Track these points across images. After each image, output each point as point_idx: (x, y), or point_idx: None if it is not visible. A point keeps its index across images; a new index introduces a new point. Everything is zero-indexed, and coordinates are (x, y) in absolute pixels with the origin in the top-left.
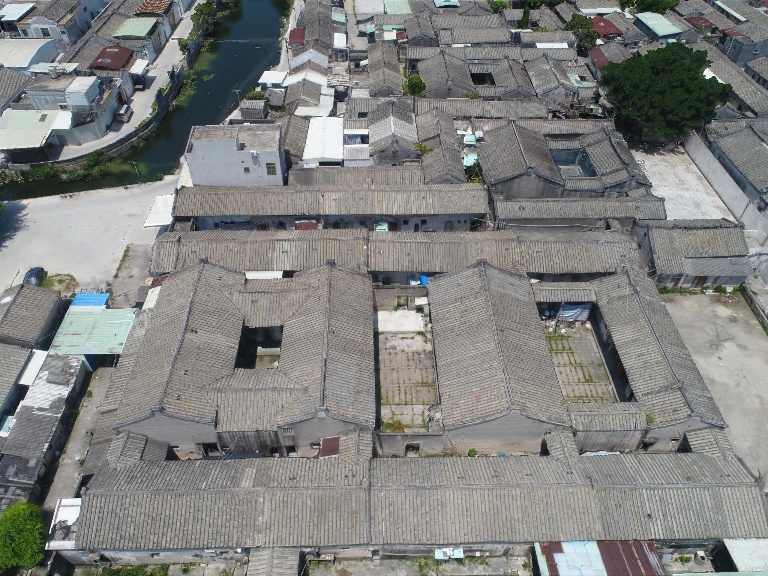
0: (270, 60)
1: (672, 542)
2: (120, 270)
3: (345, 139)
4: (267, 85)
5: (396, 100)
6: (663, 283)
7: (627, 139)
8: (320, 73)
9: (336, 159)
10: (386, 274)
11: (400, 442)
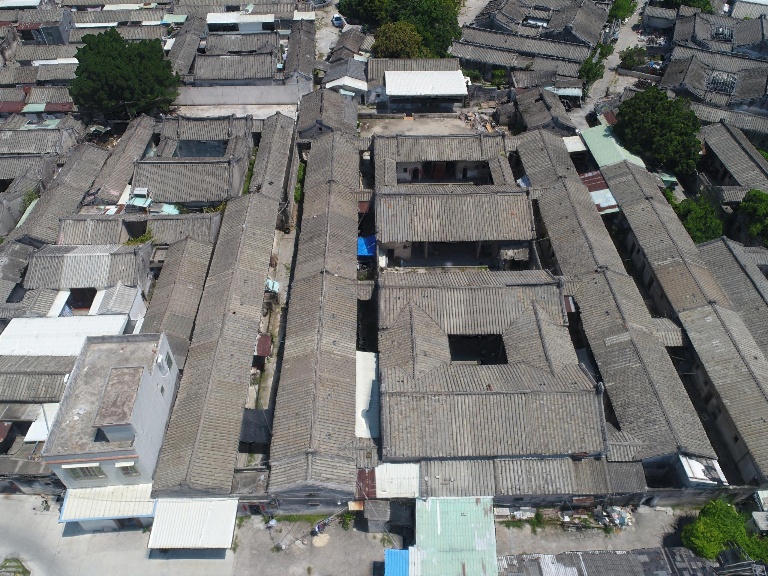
0: None
1: None
2: None
3: None
4: None
5: (6, 258)
6: None
7: None
8: None
9: (125, 321)
10: None
11: None
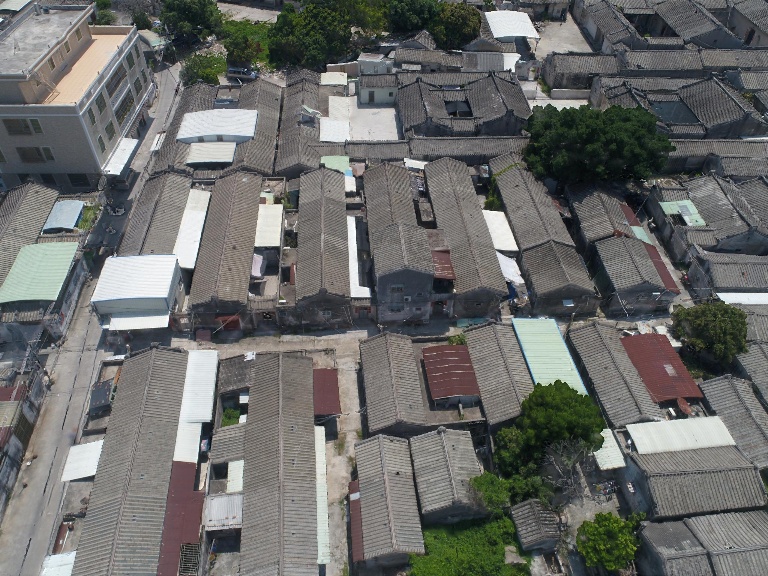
0: None
1: None
2: None
3: None
4: None
5: None
6: None
7: None
8: None
9: None
10: None
11: (717, 18)
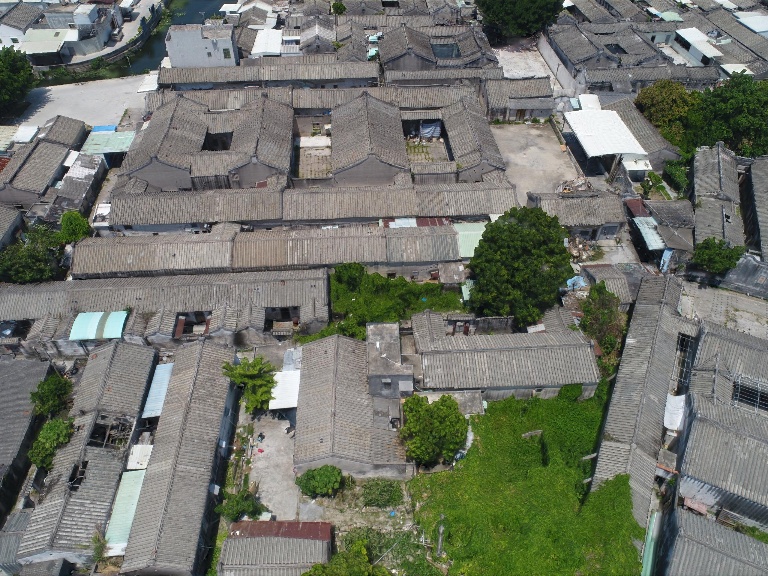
0: (230, 3)
1: (460, 218)
2: (122, 121)
3: (283, 43)
4: (226, 13)
5: (322, 17)
6: (496, 116)
7: (496, 43)
8: (267, 3)
9: (275, 53)
10: (306, 113)
11: (306, 186)
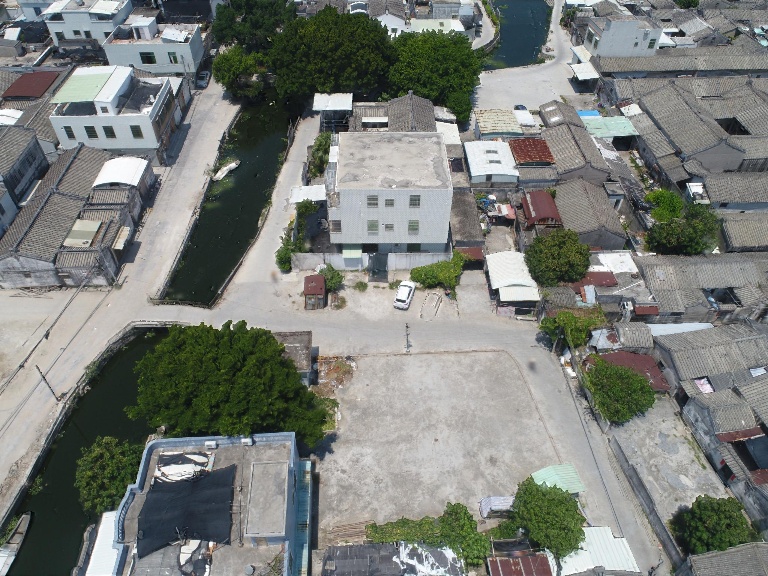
0: None
1: None
2: None
3: None
4: None
5: (685, 11)
6: None
7: None
8: None
9: (672, 44)
10: None
11: None
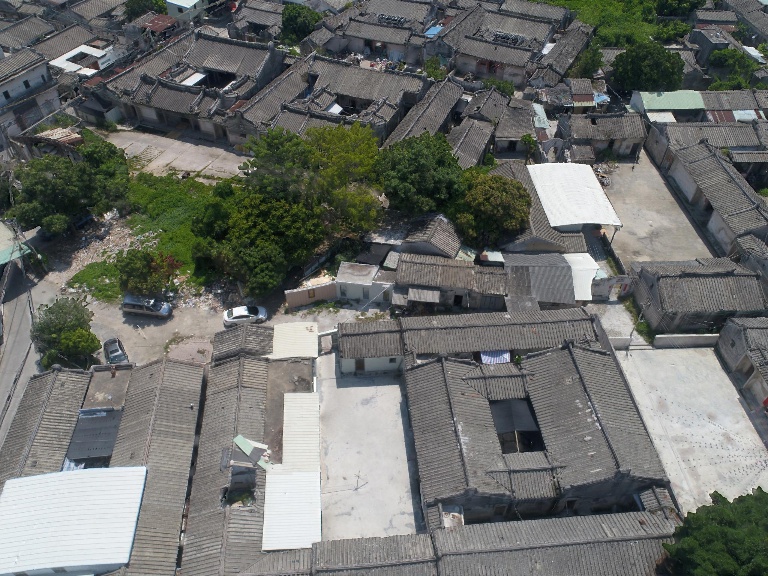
0: None
1: None
2: None
3: None
4: None
5: None
6: None
7: None
8: None
9: None
10: None
11: None
